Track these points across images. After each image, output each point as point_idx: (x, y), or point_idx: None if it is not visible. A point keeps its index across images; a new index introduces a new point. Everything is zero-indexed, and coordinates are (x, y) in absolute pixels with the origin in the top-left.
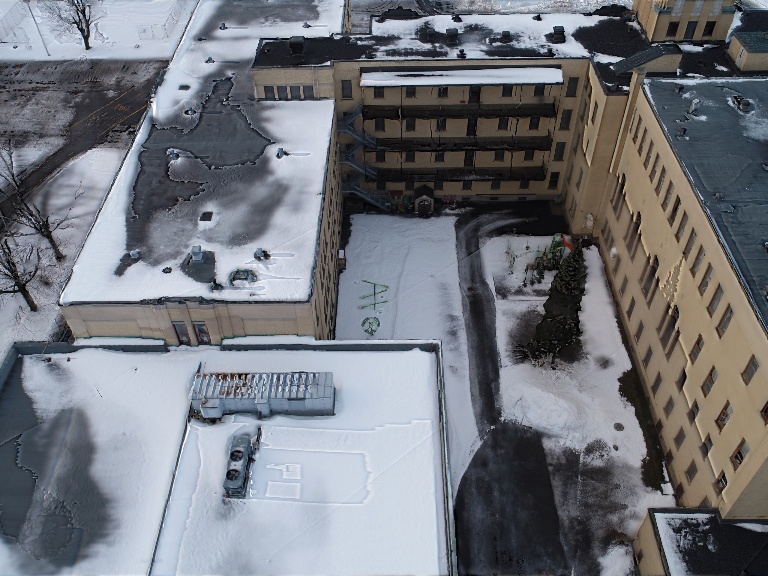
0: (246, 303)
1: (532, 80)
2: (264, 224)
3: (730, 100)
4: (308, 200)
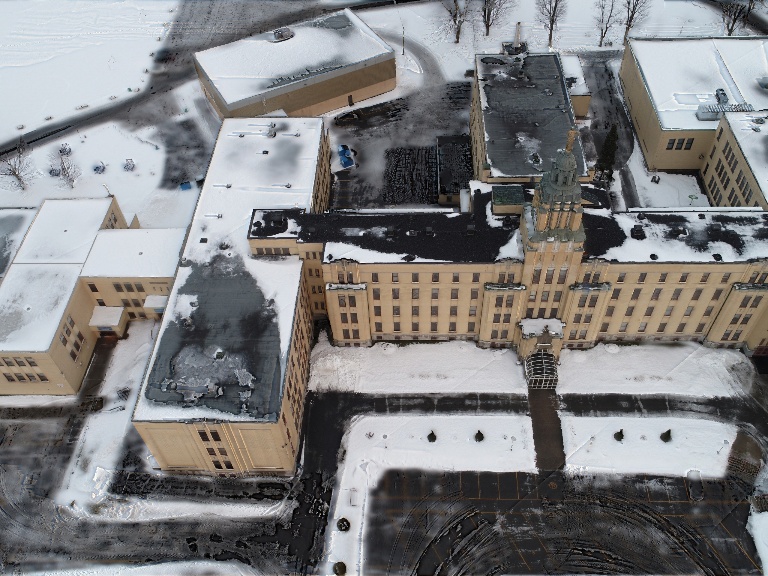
0: (750, 111)
1: (649, 209)
2: (766, 143)
3: (541, 162)
4: (752, 154)
